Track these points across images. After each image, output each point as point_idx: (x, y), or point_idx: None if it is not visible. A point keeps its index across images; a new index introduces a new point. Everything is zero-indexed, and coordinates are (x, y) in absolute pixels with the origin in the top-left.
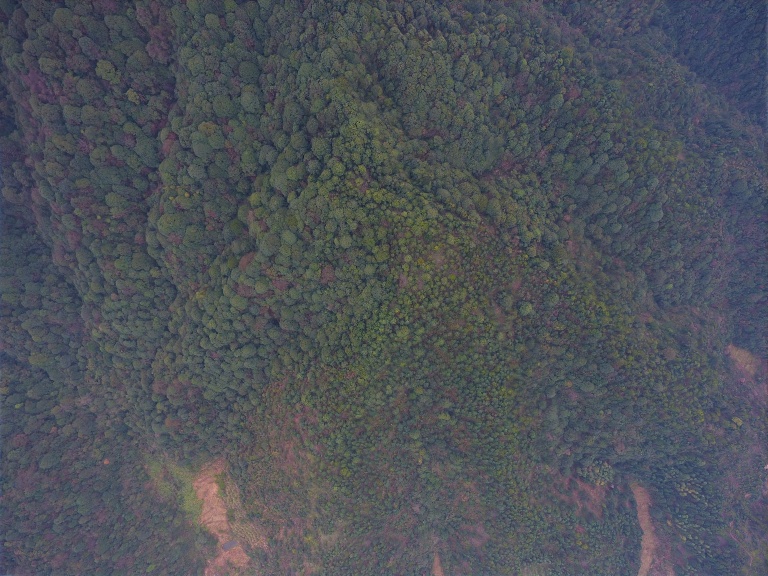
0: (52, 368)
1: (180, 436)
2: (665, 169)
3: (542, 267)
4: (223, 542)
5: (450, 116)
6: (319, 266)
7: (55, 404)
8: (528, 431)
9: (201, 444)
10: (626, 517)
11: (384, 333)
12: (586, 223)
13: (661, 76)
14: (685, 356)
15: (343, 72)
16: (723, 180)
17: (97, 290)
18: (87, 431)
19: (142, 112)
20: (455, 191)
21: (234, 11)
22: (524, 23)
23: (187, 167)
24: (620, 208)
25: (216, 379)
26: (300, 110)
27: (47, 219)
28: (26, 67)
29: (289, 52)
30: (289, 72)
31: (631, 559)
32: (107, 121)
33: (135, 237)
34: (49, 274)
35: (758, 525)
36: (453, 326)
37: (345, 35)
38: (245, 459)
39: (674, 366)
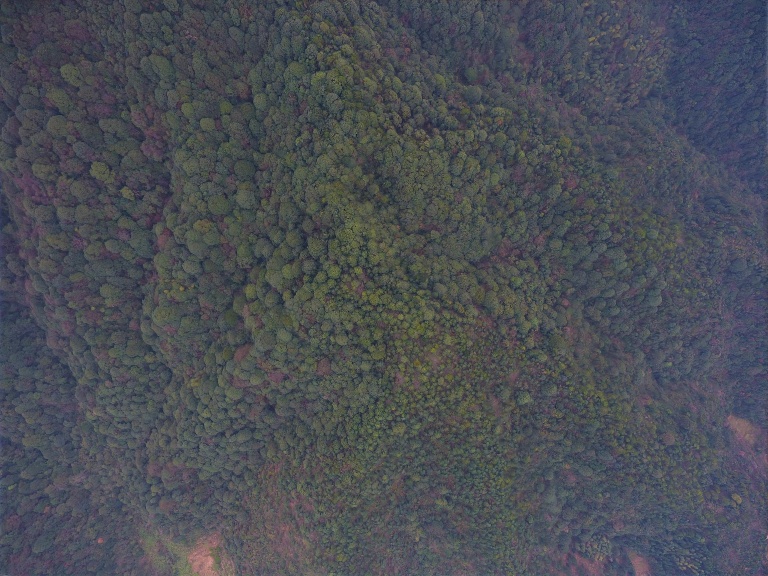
0: (46, 448)
1: (175, 515)
2: (664, 257)
3: (540, 360)
4: None
5: (447, 211)
6: (315, 360)
7: (49, 483)
8: (526, 515)
9: (196, 521)
10: None
11: (380, 428)
12: (584, 305)
13: (660, 158)
14: (684, 439)
15: (339, 177)
16: (722, 259)
17: (91, 377)
18: (81, 509)
19: (137, 207)
20: (452, 285)
21: (229, 113)
22: (522, 113)
23: (182, 262)
24: (618, 294)
25: (211, 461)
26: (296, 211)
27: (41, 309)
28: (19, 171)
29: (285, 153)
30: (285, 172)
31: None
32: (101, 218)
33: (130, 324)
34: (43, 357)
35: None
36: (450, 422)
37: (341, 141)
38: (240, 537)
39: (673, 450)
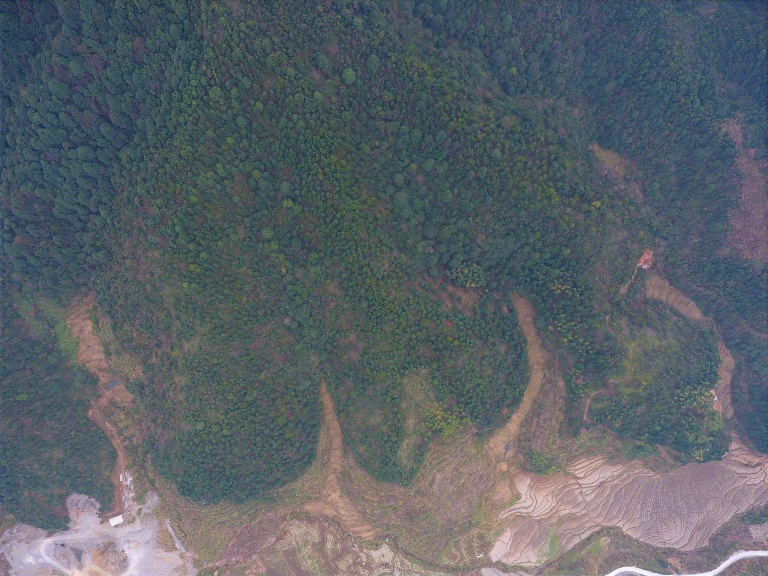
0: None
1: (36, 259)
2: None
3: (355, 25)
4: (104, 381)
5: None
6: (129, 38)
7: None
8: (375, 214)
9: (62, 271)
10: (504, 321)
11: (198, 98)
12: (415, 3)
13: None
14: (526, 129)
15: None
16: None
17: None
18: None
19: None
20: None
21: None
22: None
23: None
24: None
25: (62, 192)
26: None
27: None
28: None
29: None
30: None
31: (516, 367)
32: None
33: None
34: None
35: (636, 318)
36: (266, 84)
37: None
38: (107, 281)
39: (513, 136)
